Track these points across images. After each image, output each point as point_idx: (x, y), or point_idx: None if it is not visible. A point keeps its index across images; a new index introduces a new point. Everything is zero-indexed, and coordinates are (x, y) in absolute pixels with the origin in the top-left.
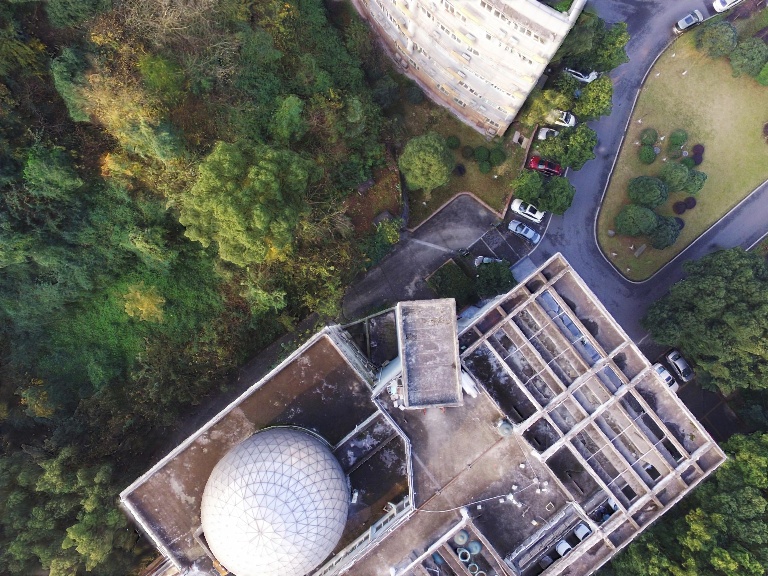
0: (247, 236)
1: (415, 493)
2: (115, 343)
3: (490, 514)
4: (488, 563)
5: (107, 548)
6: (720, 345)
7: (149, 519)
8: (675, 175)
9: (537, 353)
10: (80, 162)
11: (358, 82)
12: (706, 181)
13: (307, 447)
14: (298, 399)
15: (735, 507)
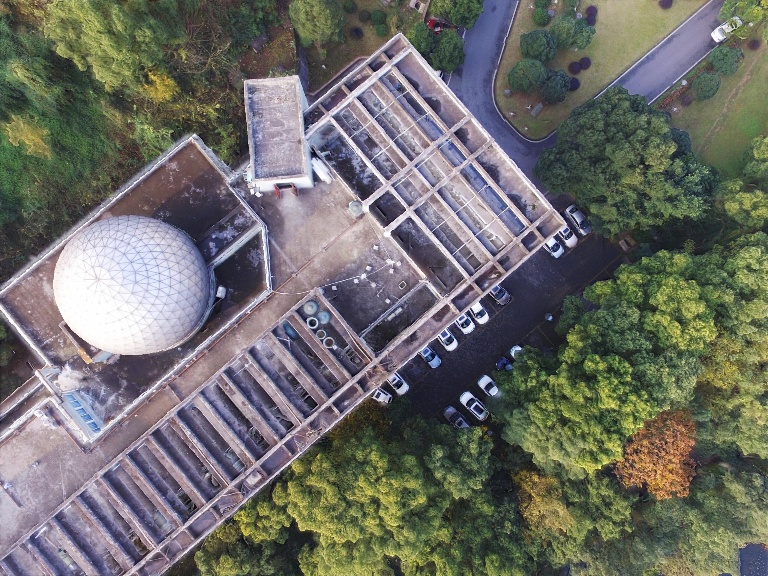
0: (109, 39)
1: (272, 276)
2: (11, 189)
3: (345, 295)
4: (338, 332)
5: None
6: (603, 179)
7: (22, 321)
8: (562, 27)
9: (381, 129)
10: None
11: None
12: (600, 42)
13: (159, 223)
14: (167, 203)
15: (611, 321)
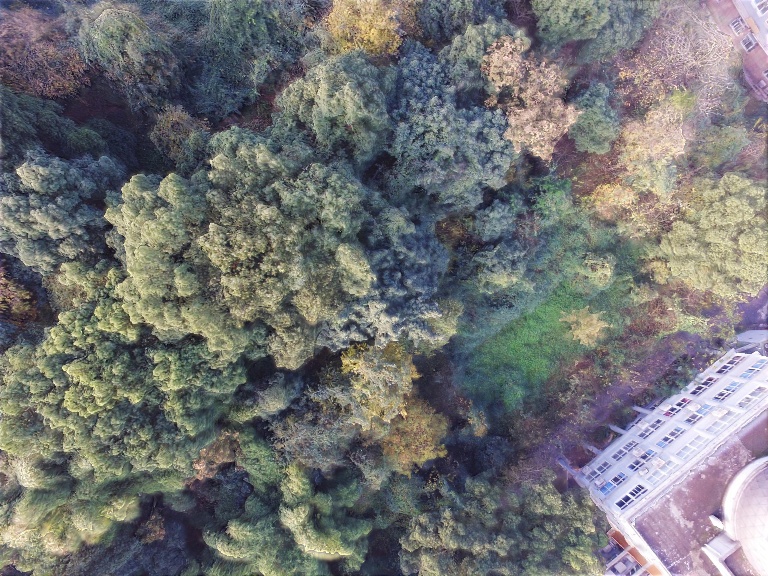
0: (766, 269)
1: None
2: (525, 364)
3: None
4: None
5: (605, 569)
6: None
7: (649, 542)
8: None
9: None
10: (575, 192)
11: (743, 110)
12: None
13: None
14: None
15: None
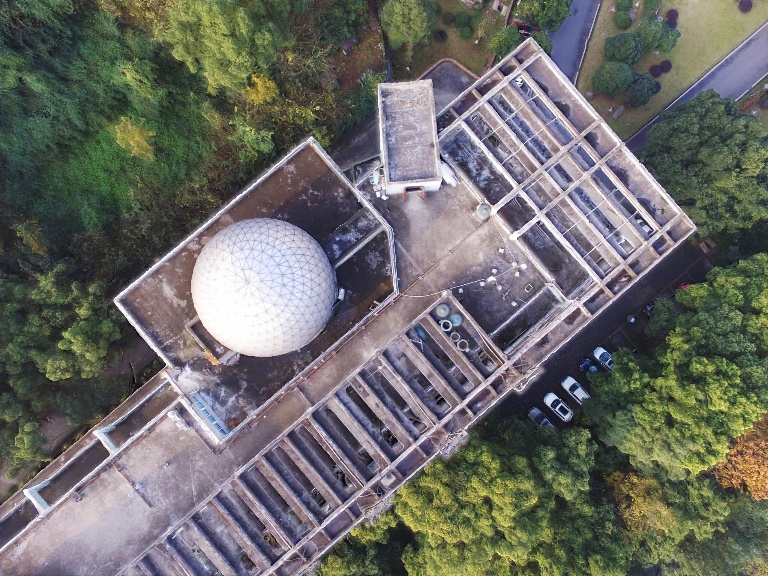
0: (232, 42)
1: (399, 279)
2: (108, 190)
3: (471, 297)
4: (470, 335)
5: (102, 352)
6: (696, 182)
7: (142, 322)
8: (649, 30)
9: (512, 133)
10: None
11: None
12: (681, 46)
13: (293, 226)
14: (285, 205)
15: (713, 323)
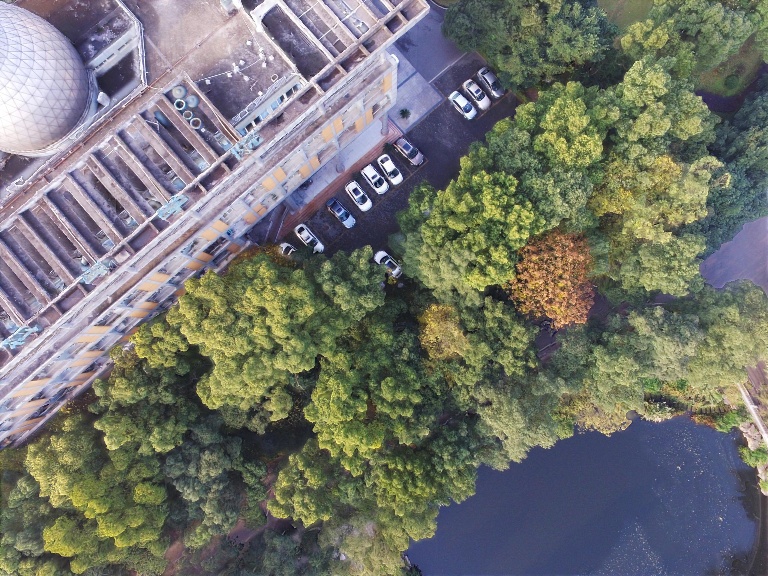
0: None
1: (147, 72)
2: None
3: (219, 89)
4: (206, 116)
5: None
6: (502, 23)
7: None
8: None
9: None
10: None
11: None
12: None
13: None
14: (52, 17)
15: (503, 147)
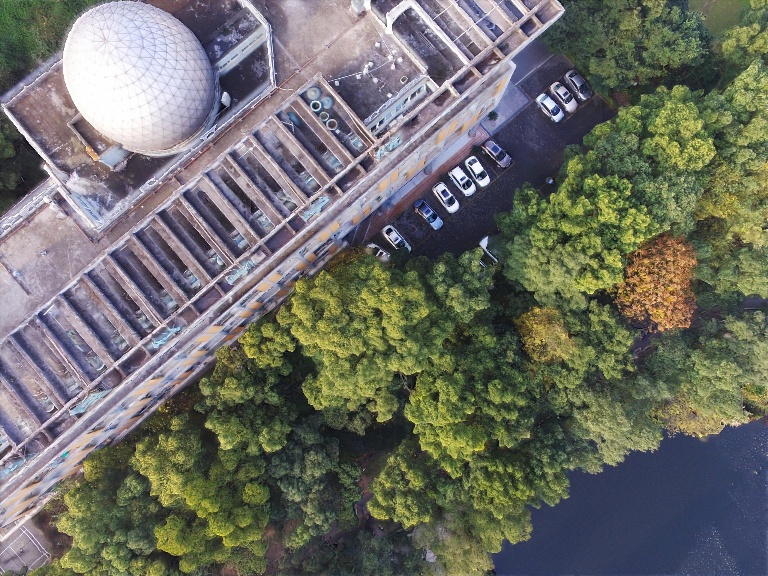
0: None
1: (276, 73)
2: (20, 39)
3: (348, 90)
4: (341, 118)
5: None
6: (601, 26)
7: (31, 130)
8: None
9: None
10: None
11: None
12: None
13: None
14: None
15: (610, 150)
